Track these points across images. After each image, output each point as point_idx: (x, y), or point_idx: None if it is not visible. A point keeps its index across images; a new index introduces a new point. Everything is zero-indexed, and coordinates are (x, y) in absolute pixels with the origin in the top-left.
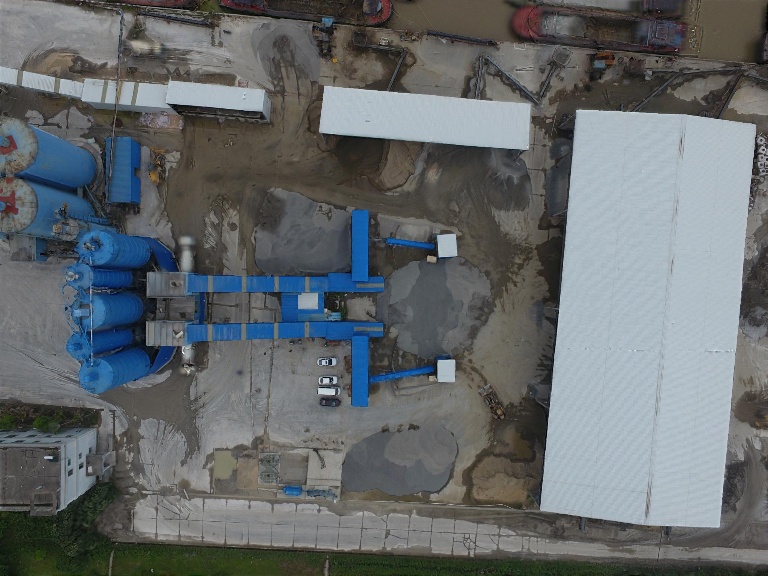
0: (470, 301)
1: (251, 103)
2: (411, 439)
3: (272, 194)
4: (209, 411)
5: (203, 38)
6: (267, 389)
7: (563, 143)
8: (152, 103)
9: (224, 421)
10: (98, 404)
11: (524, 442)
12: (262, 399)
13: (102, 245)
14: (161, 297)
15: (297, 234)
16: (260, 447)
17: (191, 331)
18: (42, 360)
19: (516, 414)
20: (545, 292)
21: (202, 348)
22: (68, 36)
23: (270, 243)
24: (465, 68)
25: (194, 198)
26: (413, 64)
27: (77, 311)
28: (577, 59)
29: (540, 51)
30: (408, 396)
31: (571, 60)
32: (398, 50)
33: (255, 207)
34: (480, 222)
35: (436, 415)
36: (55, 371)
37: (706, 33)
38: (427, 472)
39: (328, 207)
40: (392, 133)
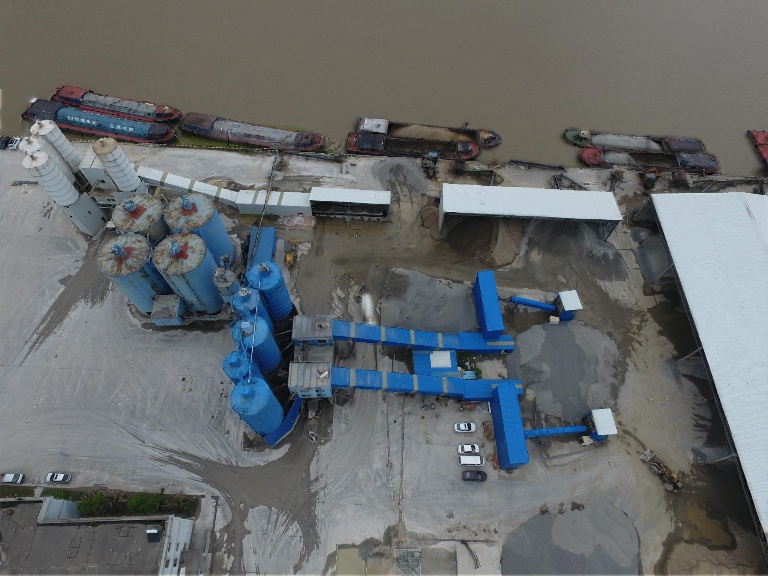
0: (604, 355)
1: (380, 199)
2: (579, 520)
3: (394, 272)
4: (332, 494)
5: (333, 169)
6: (399, 463)
7: (640, 230)
8: (295, 204)
9: (350, 506)
10: (200, 489)
11: (714, 522)
12: (394, 476)
13: (271, 272)
14: (306, 338)
15: (423, 300)
16: (394, 541)
17: (334, 373)
18: (144, 437)
19: (691, 485)
20: (672, 350)
21: (326, 417)
22: (226, 169)
23: (398, 308)
24: (543, 184)
25: (322, 277)
26: (501, 182)
27: (246, 322)
28: (629, 177)
29: (598, 173)
30: (562, 466)
31: (625, 178)
32: (490, 170)
33: (379, 283)
34: (589, 291)
35: (600, 489)
36: (156, 449)
37: (720, 160)
38: (613, 562)
39: (447, 281)
40: (505, 211)
